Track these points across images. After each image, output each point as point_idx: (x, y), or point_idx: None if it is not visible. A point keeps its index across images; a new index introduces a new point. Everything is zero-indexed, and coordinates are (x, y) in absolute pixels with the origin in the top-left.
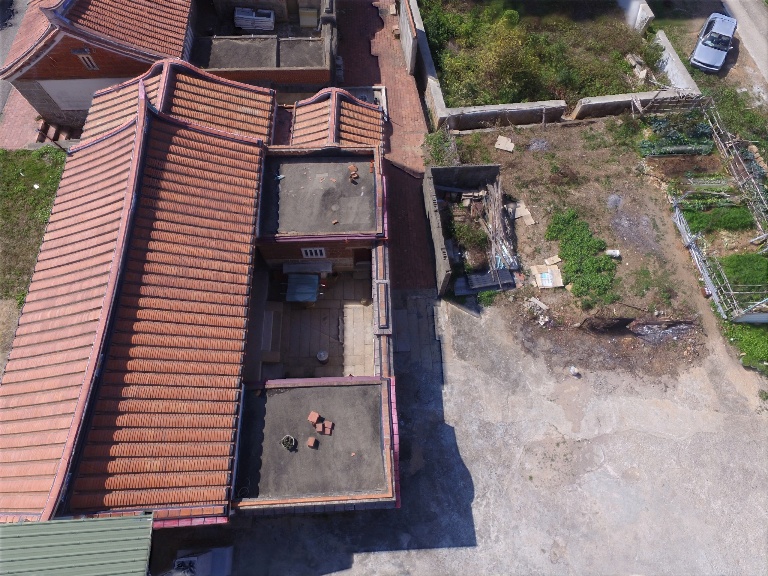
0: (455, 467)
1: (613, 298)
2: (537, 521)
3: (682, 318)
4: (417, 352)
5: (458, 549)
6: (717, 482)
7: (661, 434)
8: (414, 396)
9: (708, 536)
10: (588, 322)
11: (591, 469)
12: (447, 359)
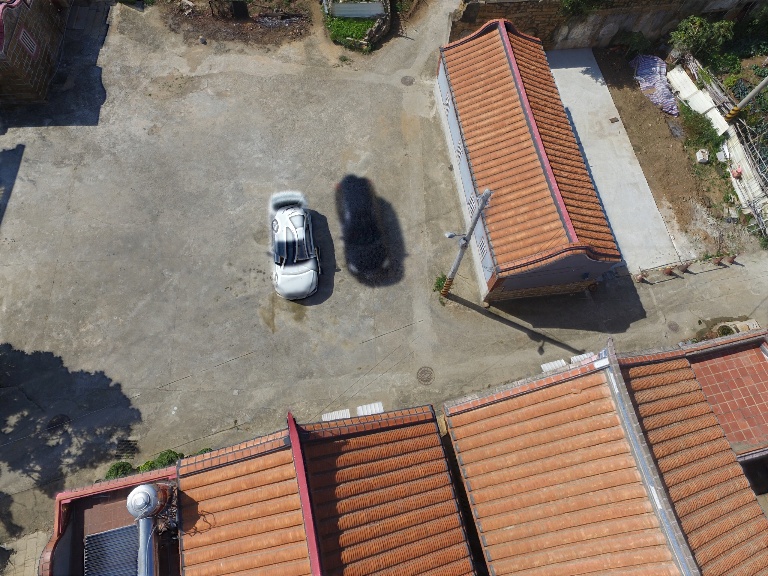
0: (96, 88)
1: (246, 0)
2: (146, 115)
3: (294, 12)
4: (89, 30)
5: (83, 127)
6: (285, 99)
7: (254, 73)
8: (78, 52)
9: (266, 124)
10: (218, 10)
11: (196, 91)
12: (111, 34)
